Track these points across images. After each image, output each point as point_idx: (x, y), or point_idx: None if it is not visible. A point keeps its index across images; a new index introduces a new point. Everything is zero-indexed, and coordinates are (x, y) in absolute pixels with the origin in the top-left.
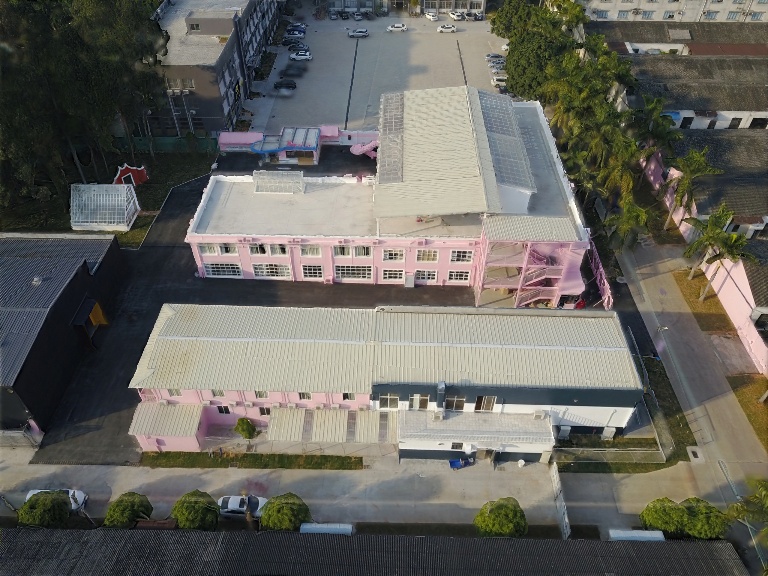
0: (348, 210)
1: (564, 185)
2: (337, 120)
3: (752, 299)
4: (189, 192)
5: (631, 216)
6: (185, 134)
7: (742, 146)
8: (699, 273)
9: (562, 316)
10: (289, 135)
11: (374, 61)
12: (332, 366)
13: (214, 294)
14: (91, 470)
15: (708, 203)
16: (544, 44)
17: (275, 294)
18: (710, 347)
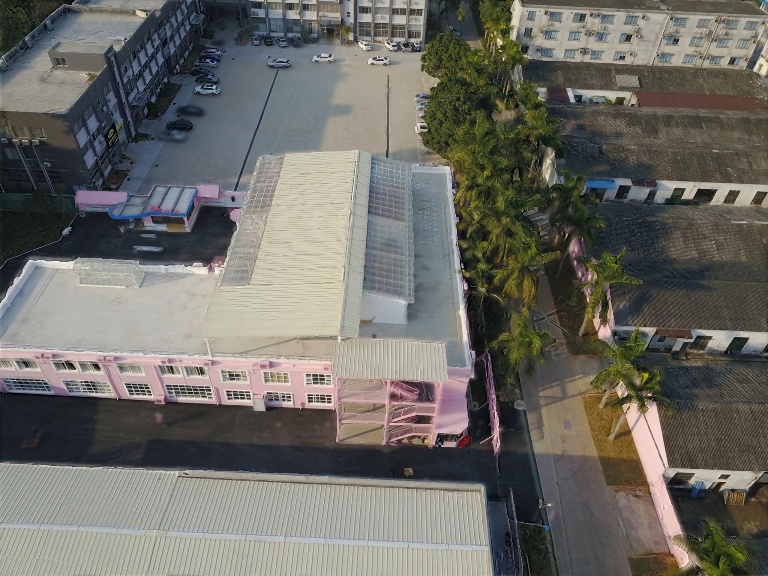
0: (187, 313)
1: (458, 284)
2: (230, 172)
3: (665, 456)
4: None
5: (523, 342)
6: (42, 188)
7: (678, 231)
8: (613, 398)
9: (417, 488)
10: (159, 196)
11: (290, 98)
12: (92, 571)
13: (11, 418)
14: None
15: (628, 311)
16: (463, 96)
17: (89, 418)
18: (614, 510)
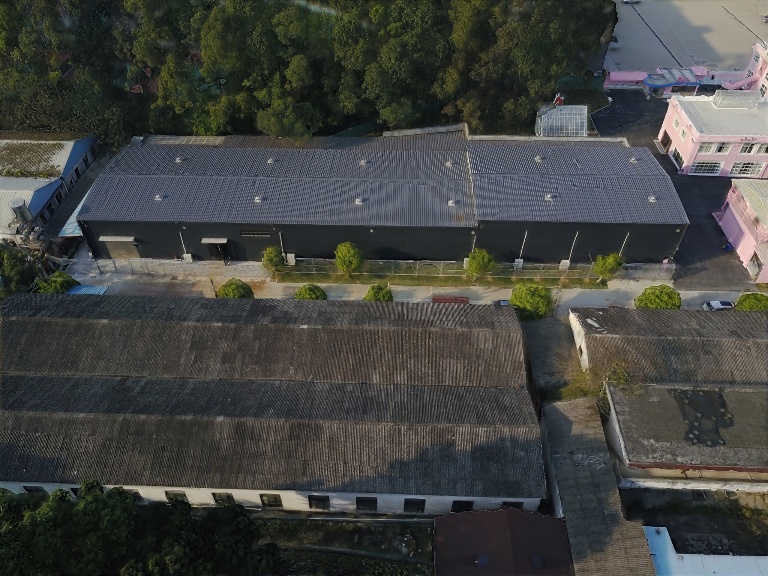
0: None
1: None
2: (674, 67)
3: None
4: (606, 118)
5: None
6: None
7: None
8: None
9: None
10: (668, 74)
11: (663, 22)
12: None
13: (706, 186)
14: (727, 294)
15: None
16: None
17: None
18: None
